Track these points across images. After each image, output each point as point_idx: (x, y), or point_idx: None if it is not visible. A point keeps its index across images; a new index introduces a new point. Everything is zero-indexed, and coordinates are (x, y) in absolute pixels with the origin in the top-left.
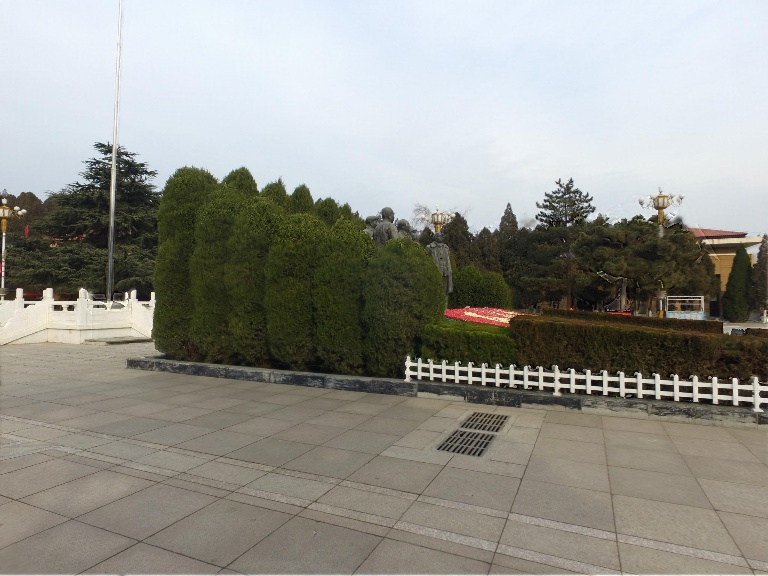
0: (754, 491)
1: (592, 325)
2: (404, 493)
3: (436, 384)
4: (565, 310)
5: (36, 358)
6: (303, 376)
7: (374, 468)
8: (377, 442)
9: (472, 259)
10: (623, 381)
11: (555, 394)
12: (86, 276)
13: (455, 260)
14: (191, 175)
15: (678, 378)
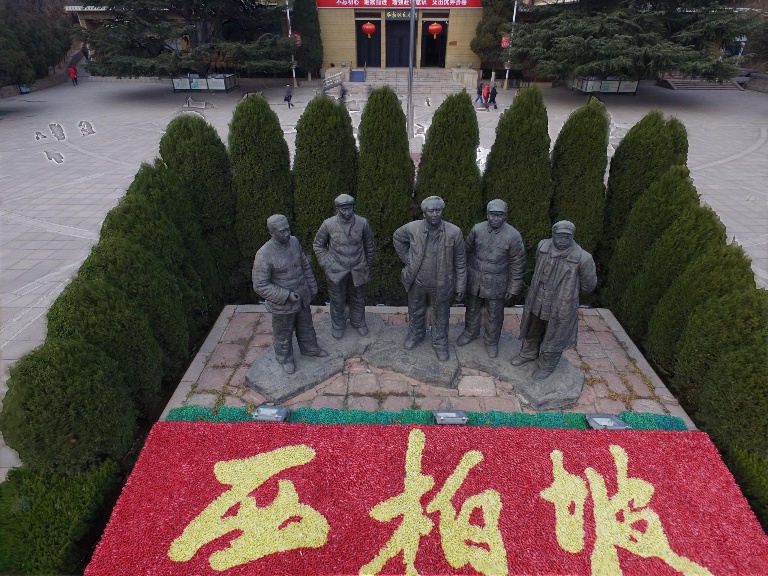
0: None
1: None
2: None
3: None
4: None
5: None
6: None
7: None
8: None
9: None
10: None
11: None
12: (555, 57)
13: None
14: (168, 132)
15: None
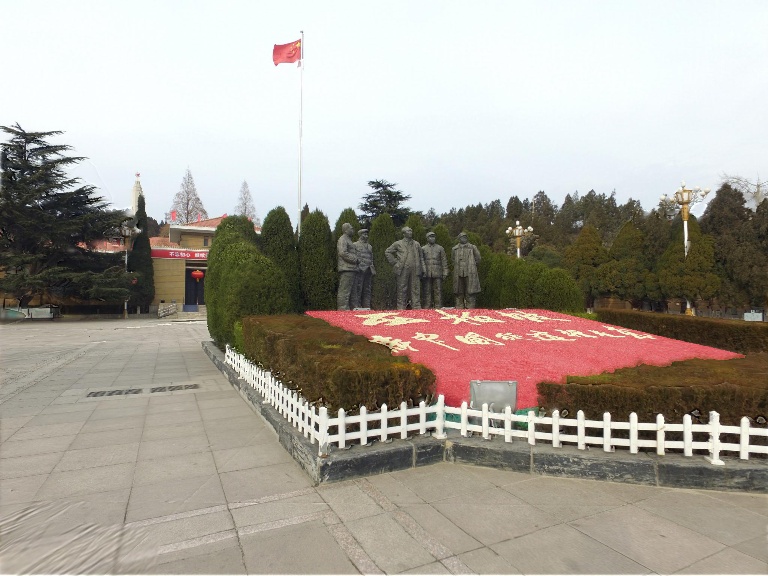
0: (67, 429)
1: (256, 323)
2: (6, 399)
3: (226, 365)
4: (617, 311)
5: (198, 340)
6: (214, 356)
7: (42, 392)
8: (91, 386)
9: (741, 244)
10: (248, 370)
11: (238, 377)
12: None
13: (712, 247)
14: (226, 221)
15: (255, 369)
